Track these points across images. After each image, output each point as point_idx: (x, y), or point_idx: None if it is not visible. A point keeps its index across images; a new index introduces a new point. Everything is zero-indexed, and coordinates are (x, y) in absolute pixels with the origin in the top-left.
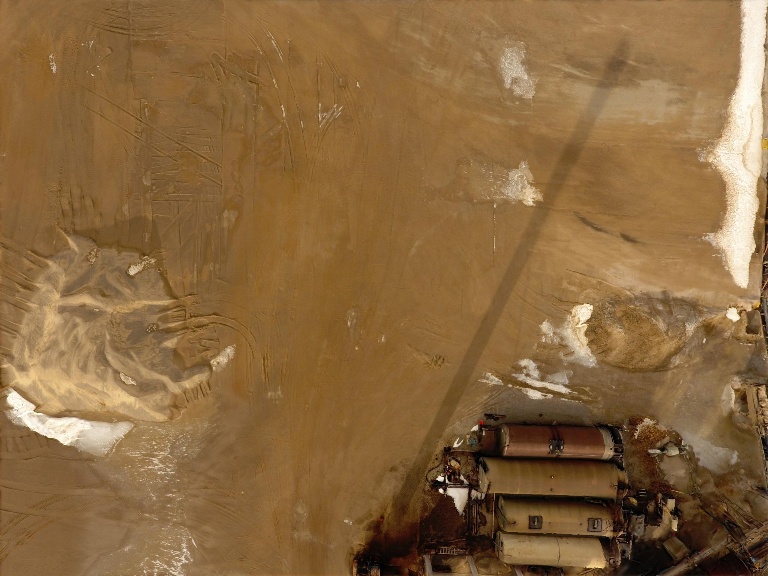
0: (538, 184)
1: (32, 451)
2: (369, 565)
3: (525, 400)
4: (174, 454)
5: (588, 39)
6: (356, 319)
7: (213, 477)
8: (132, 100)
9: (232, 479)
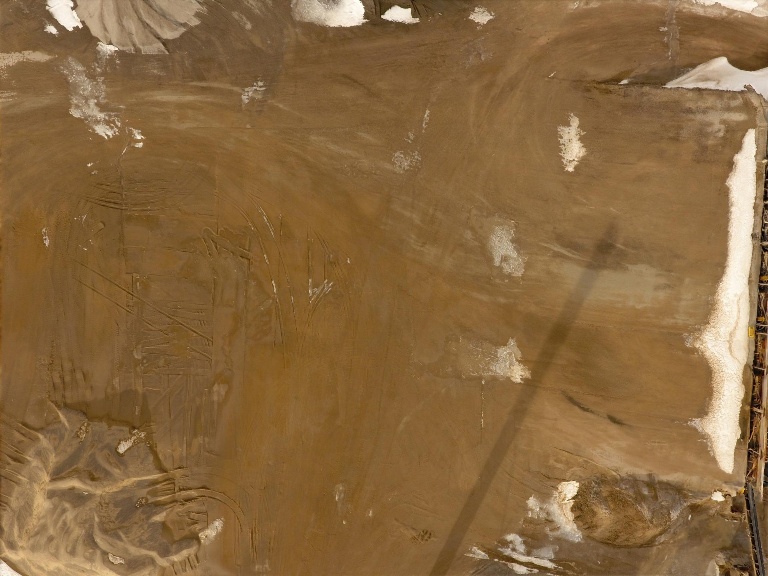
0: (526, 361)
1: None
2: None
3: (511, 575)
4: None
5: (577, 220)
6: (344, 493)
7: None
8: (124, 274)
9: None
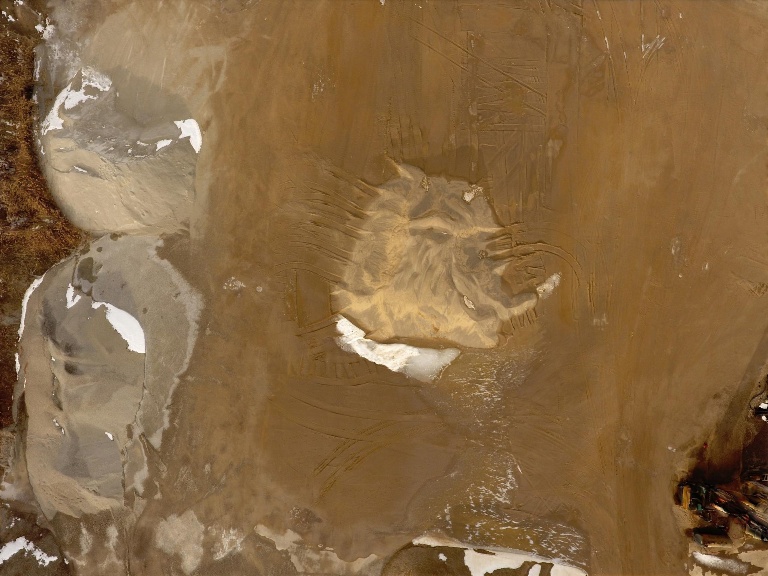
0: None
1: (361, 377)
2: (710, 488)
3: None
4: (500, 381)
5: None
6: (680, 247)
7: (539, 403)
8: (459, 32)
9: (558, 405)
